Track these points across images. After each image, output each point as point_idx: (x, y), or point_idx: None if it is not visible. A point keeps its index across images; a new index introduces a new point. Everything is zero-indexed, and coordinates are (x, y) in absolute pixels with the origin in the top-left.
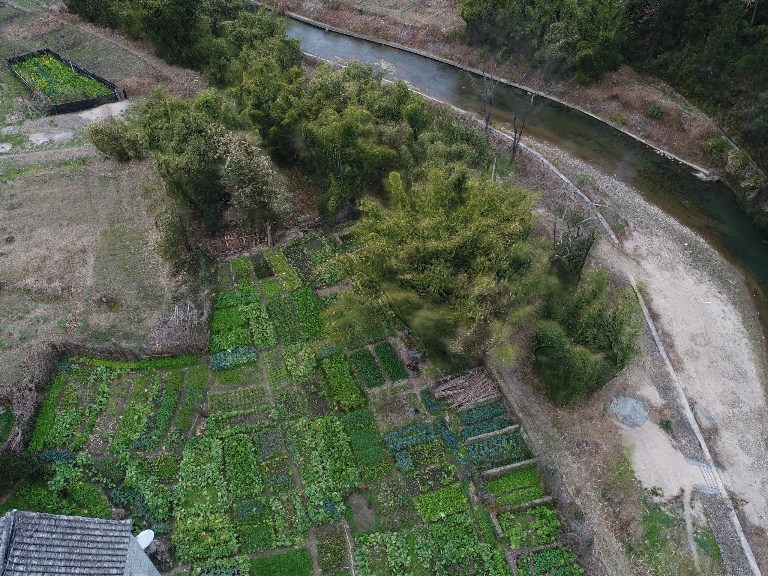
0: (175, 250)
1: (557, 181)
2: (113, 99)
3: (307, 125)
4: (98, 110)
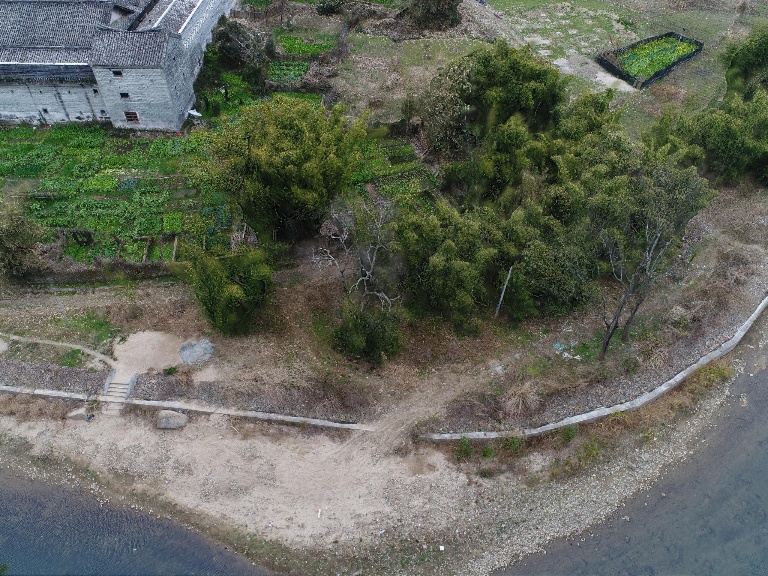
0: (404, 110)
1: (549, 388)
2: (632, 82)
3: (510, 118)
4: (610, 78)
